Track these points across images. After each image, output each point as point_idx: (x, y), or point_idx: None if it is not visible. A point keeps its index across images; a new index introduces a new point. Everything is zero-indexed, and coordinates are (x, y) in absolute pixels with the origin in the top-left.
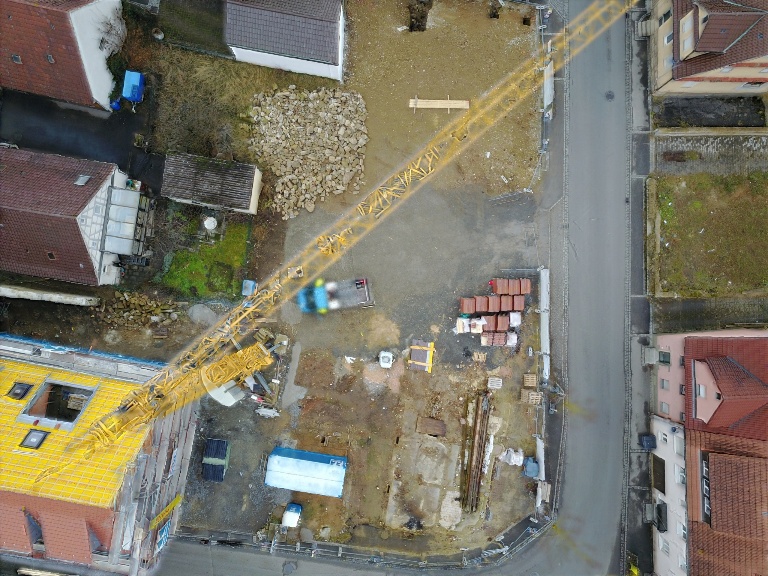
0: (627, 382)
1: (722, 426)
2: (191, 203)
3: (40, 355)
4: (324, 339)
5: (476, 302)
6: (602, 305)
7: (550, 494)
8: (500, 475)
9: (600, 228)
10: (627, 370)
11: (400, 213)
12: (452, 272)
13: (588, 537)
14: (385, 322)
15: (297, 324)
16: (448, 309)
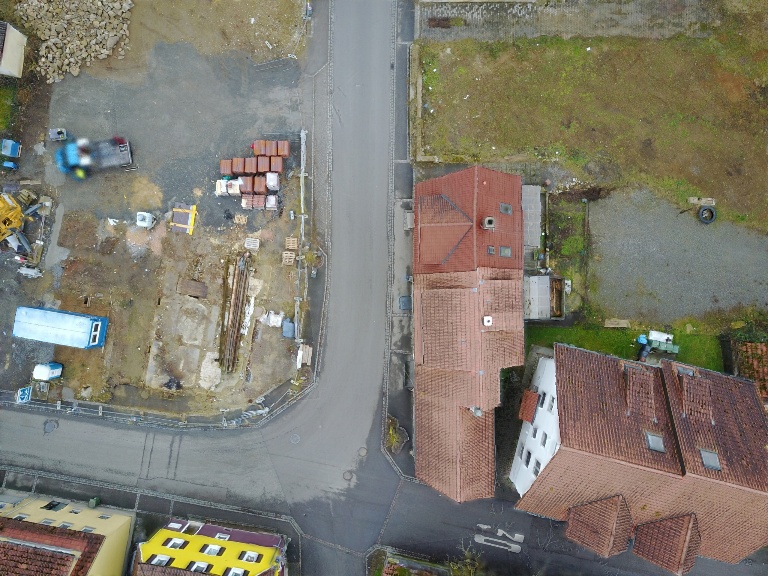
0: (390, 247)
1: (435, 263)
2: None
3: None
4: (87, 201)
5: (232, 162)
6: (366, 170)
7: (312, 357)
8: (261, 337)
9: (365, 94)
10: (390, 235)
11: (164, 78)
12: (215, 136)
13: (349, 400)
14: (148, 185)
15: (60, 186)
16: (210, 172)
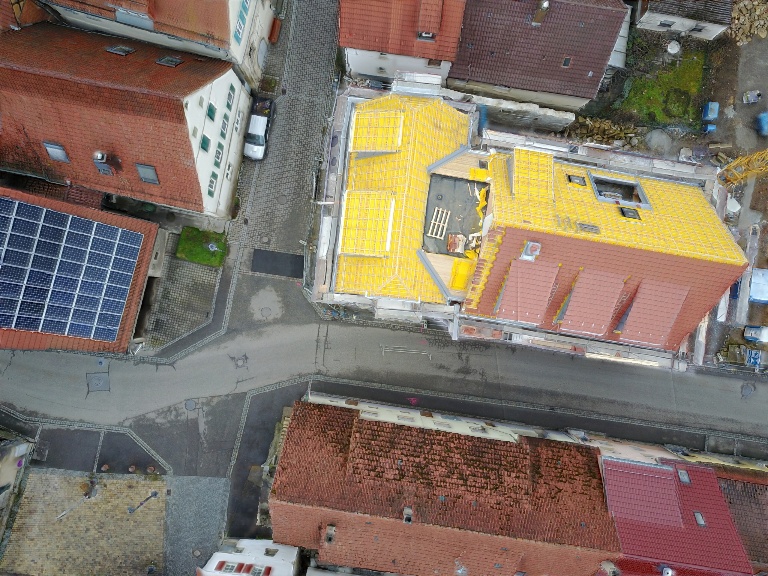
0: None
1: None
2: (651, 28)
3: (577, 153)
4: None
5: None
6: None
7: None
8: None
9: None
10: None
11: None
12: None
13: None
14: None
15: (752, 148)
16: None
